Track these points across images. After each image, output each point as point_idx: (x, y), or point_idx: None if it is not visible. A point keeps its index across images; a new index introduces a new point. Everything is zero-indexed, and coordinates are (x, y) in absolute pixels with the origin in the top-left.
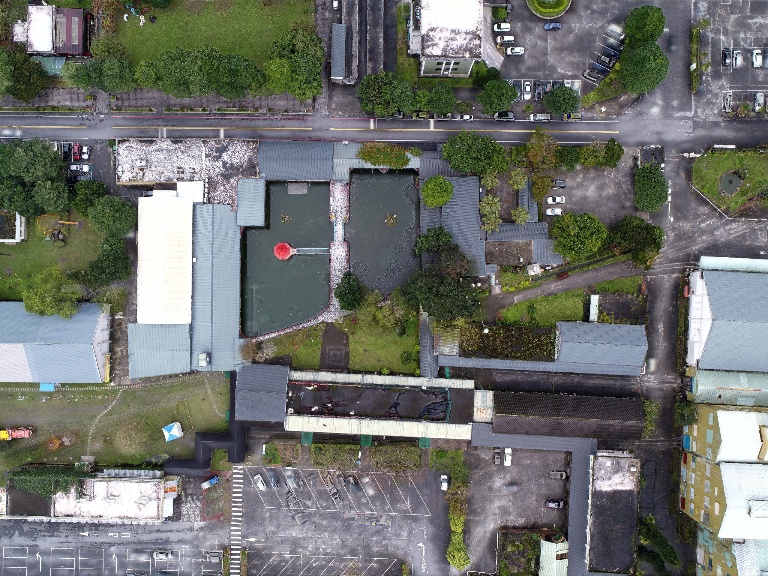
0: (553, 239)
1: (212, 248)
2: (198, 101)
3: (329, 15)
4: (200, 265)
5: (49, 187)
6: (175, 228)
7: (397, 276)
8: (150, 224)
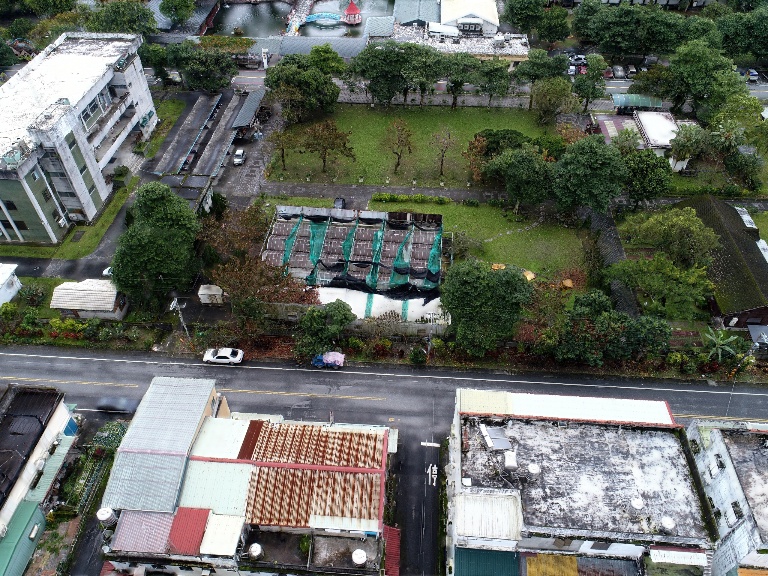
0: (80, 4)
1: (420, 2)
2: (441, 99)
3: (254, 154)
4: (433, 0)
5: (591, 3)
6: (457, 6)
7: (246, 14)
8: (483, 8)
